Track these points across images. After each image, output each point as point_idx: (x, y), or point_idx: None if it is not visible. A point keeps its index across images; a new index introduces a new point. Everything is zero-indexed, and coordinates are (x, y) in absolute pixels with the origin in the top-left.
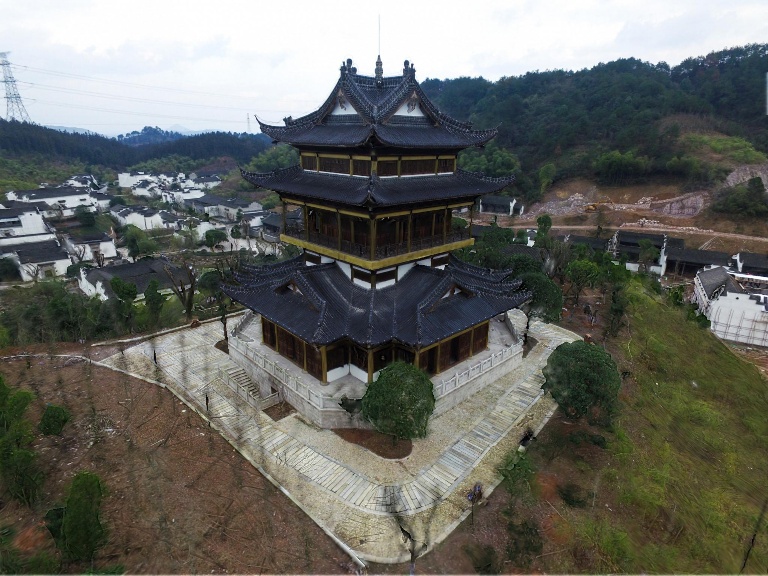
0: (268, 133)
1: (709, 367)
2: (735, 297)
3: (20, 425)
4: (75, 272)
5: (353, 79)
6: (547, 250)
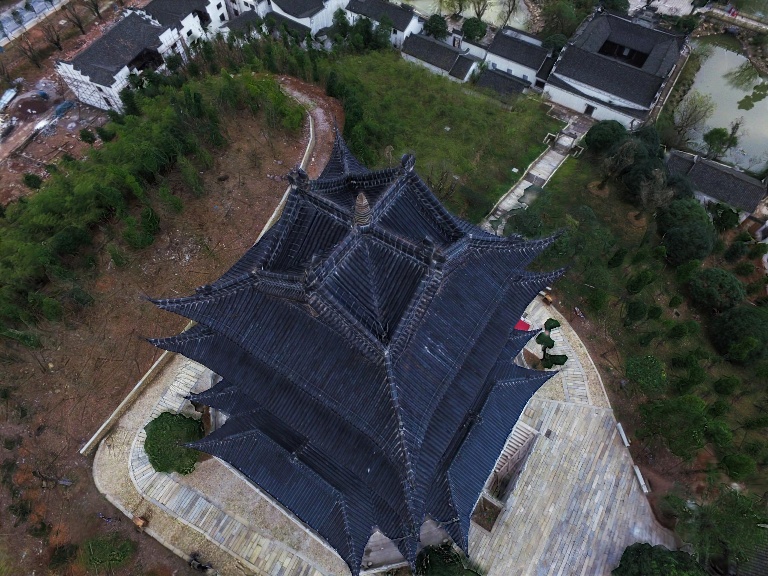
0: (334, 146)
1: None
2: None
3: (130, 231)
4: (605, 3)
5: (309, 198)
6: None
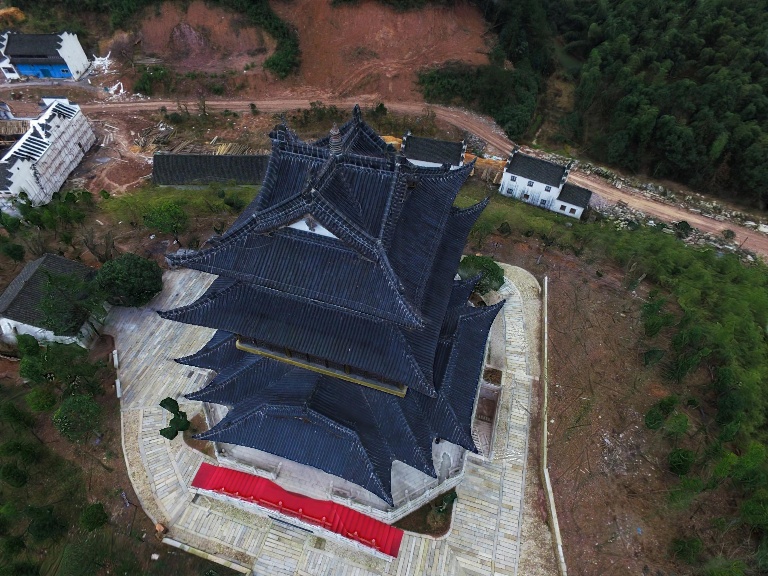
0: None
1: (213, 199)
2: (17, 169)
3: None
4: None
5: None
6: (88, 247)
